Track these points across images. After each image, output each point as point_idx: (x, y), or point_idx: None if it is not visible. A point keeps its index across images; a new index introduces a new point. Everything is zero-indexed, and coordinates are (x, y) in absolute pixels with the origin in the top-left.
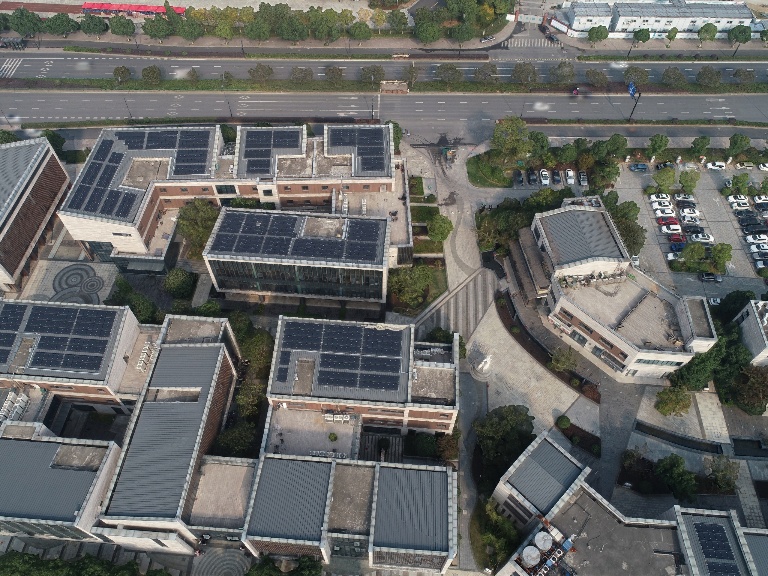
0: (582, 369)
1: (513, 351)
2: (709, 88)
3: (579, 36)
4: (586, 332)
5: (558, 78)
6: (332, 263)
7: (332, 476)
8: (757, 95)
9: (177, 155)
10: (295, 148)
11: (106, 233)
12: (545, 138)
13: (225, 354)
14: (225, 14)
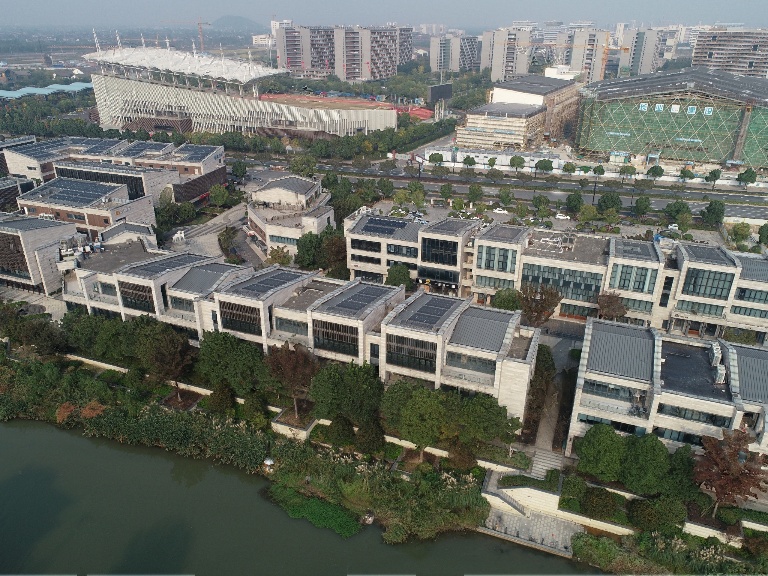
0: (246, 255)
1: (211, 245)
2: (498, 185)
3: (430, 164)
4: (256, 230)
5: (382, 166)
6: (115, 169)
7: (6, 215)
8: (535, 191)
9: (93, 147)
10: (159, 150)
11: (24, 167)
12: (335, 177)
13: (18, 189)
14: (203, 135)
